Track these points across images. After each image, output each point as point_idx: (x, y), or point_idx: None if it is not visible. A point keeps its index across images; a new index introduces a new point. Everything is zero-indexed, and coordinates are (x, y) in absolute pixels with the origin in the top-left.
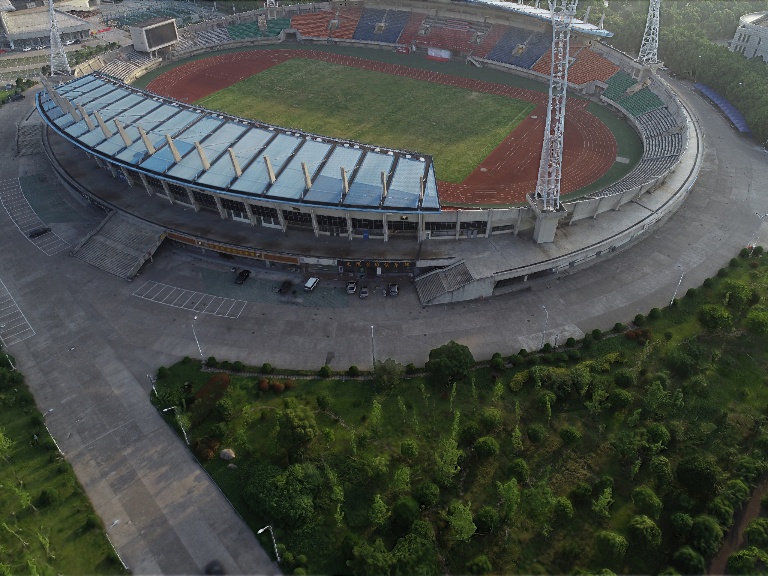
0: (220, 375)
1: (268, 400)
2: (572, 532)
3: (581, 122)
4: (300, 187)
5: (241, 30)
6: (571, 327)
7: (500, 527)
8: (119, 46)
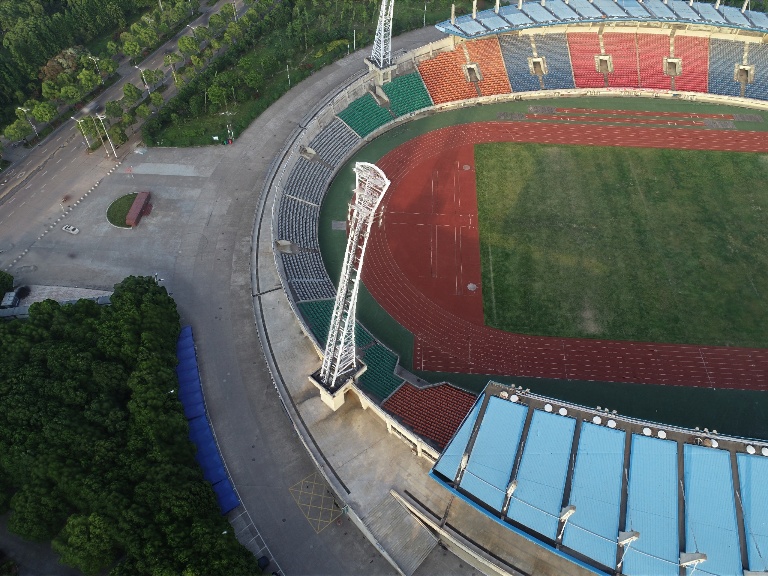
0: (483, 6)
1: (456, 8)
2: (324, 6)
3: (407, 294)
4: (524, 7)
5: None
6: (343, 65)
7: (348, 1)
8: None
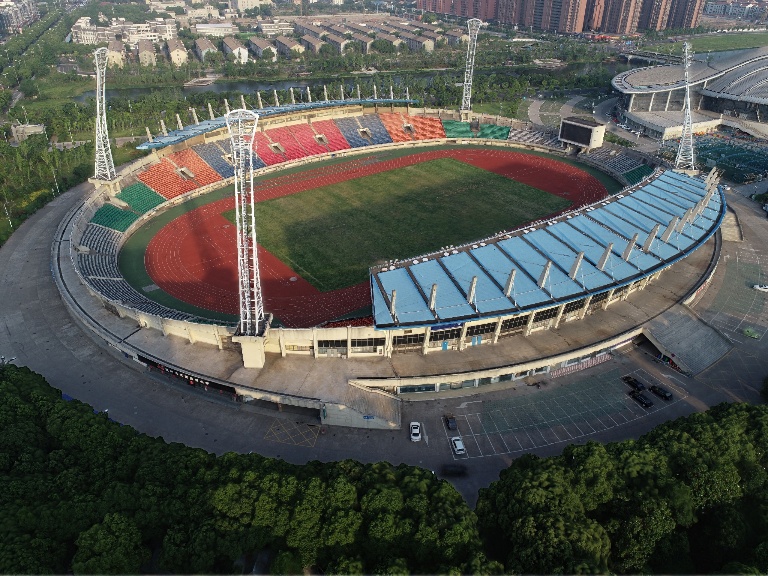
0: None
1: None
2: None
3: None
4: None
5: (643, 173)
6: None
7: None
8: (624, 145)
